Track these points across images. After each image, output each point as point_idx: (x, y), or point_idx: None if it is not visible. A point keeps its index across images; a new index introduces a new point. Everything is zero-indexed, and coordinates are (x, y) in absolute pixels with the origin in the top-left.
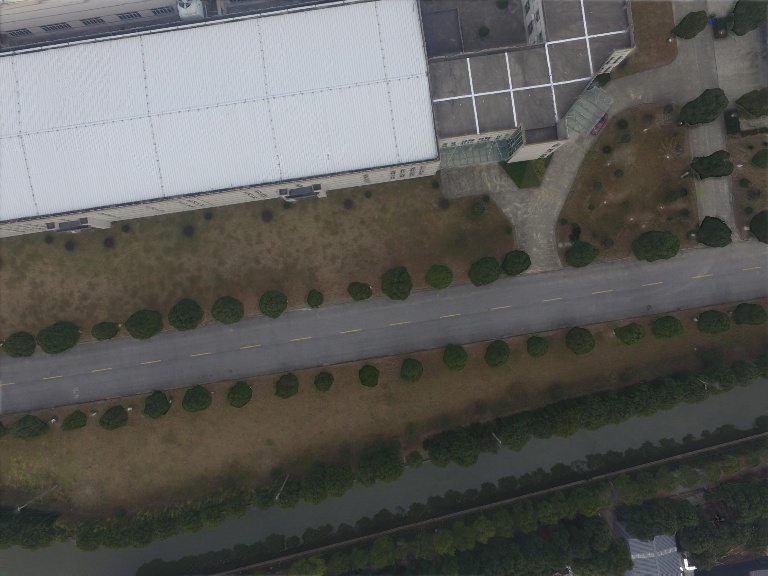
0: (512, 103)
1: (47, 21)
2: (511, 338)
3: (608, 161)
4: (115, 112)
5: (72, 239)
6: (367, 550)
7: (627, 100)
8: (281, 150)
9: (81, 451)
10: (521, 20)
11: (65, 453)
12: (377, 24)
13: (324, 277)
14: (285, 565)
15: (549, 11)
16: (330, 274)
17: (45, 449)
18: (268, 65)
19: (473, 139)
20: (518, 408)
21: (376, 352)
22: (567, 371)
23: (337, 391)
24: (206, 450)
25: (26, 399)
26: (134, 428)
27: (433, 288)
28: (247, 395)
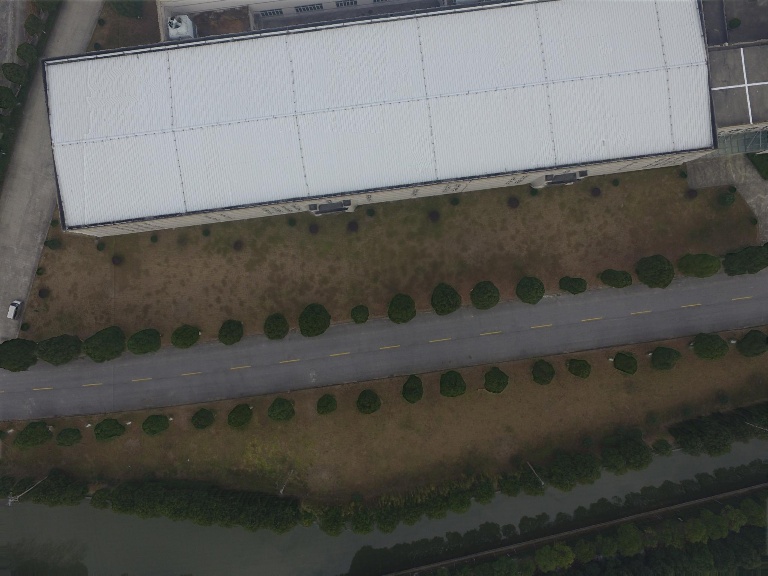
0: None
1: (306, 2)
2: None
3: None
4: (392, 94)
5: (315, 222)
6: (613, 538)
7: None
8: (557, 135)
9: (318, 435)
10: None
11: (301, 437)
12: (656, 12)
13: (567, 265)
14: (524, 552)
15: None
16: (573, 262)
17: (281, 433)
18: (547, 50)
19: (741, 129)
20: (758, 398)
21: (616, 340)
22: None
23: (577, 379)
24: (444, 436)
25: (262, 382)
26: (373, 413)
27: (680, 277)
28: (507, 381)
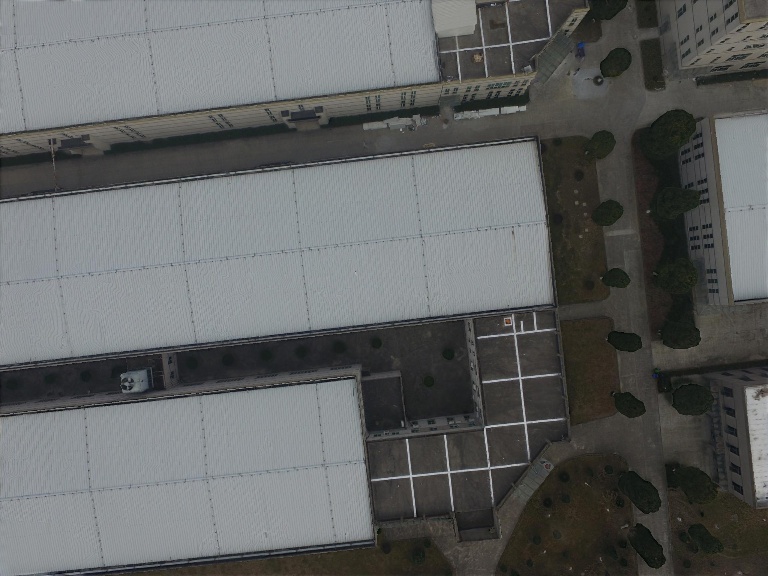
0: (449, 485)
1: None
2: None
3: (549, 512)
4: (57, 486)
5: None
6: None
7: (570, 450)
8: (220, 527)
9: None
10: (467, 368)
11: None
12: (317, 407)
13: None
14: None
15: (489, 395)
16: None
17: None
18: (209, 444)
19: None
20: None
21: None
22: None
23: None
24: None
25: None
26: None
27: None
28: None
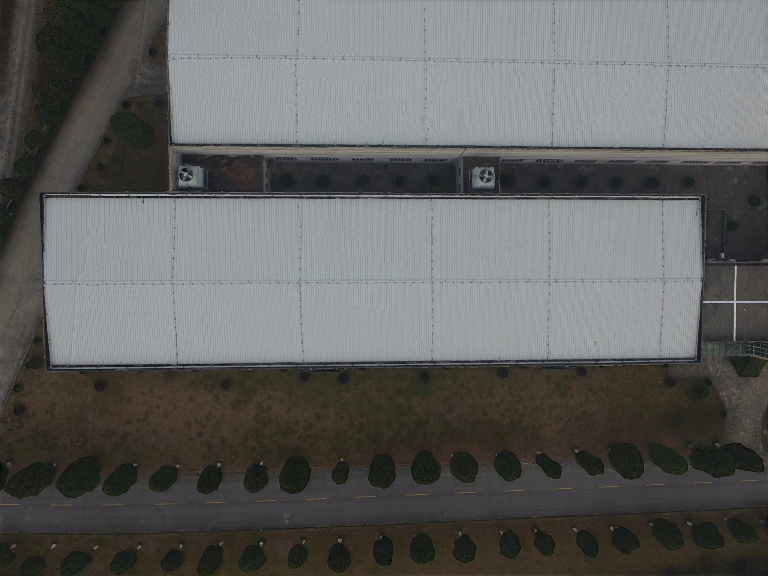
0: None
1: (322, 156)
2: (707, 511)
3: None
4: (398, 273)
5: None
6: None
7: None
8: (553, 331)
9: (285, 575)
10: (766, 218)
11: (269, 575)
12: (661, 223)
13: (546, 436)
14: None
15: None
16: (552, 434)
17: None
18: (553, 248)
19: None
20: None
21: (582, 511)
22: (752, 547)
23: None
24: None
25: (235, 519)
26: None
27: None
28: None
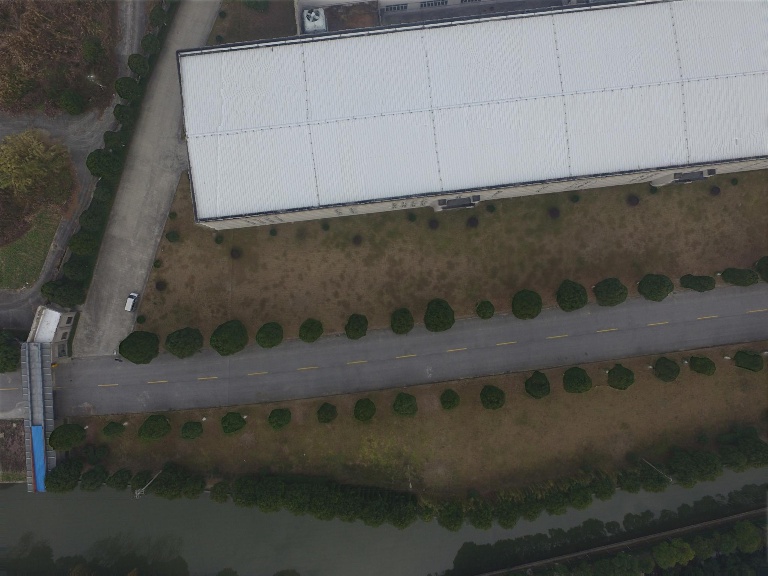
0: None
1: None
2: None
3: None
4: (528, 90)
5: (434, 217)
6: (730, 535)
7: None
8: (690, 134)
9: (434, 431)
10: None
11: (418, 433)
12: None
13: (685, 263)
14: (639, 549)
15: None
16: (691, 260)
17: (397, 428)
18: (681, 49)
19: None
20: None
21: (731, 339)
22: None
23: (693, 376)
24: (560, 432)
25: (378, 377)
26: (490, 409)
27: None
28: None
